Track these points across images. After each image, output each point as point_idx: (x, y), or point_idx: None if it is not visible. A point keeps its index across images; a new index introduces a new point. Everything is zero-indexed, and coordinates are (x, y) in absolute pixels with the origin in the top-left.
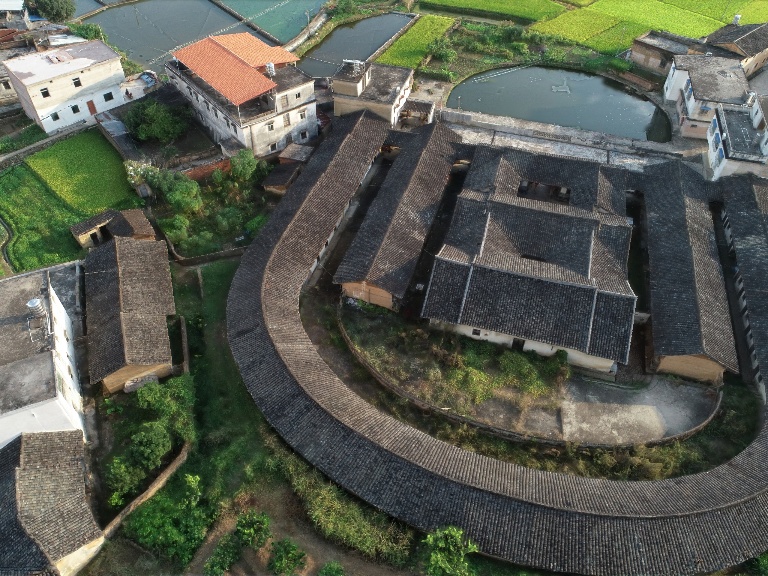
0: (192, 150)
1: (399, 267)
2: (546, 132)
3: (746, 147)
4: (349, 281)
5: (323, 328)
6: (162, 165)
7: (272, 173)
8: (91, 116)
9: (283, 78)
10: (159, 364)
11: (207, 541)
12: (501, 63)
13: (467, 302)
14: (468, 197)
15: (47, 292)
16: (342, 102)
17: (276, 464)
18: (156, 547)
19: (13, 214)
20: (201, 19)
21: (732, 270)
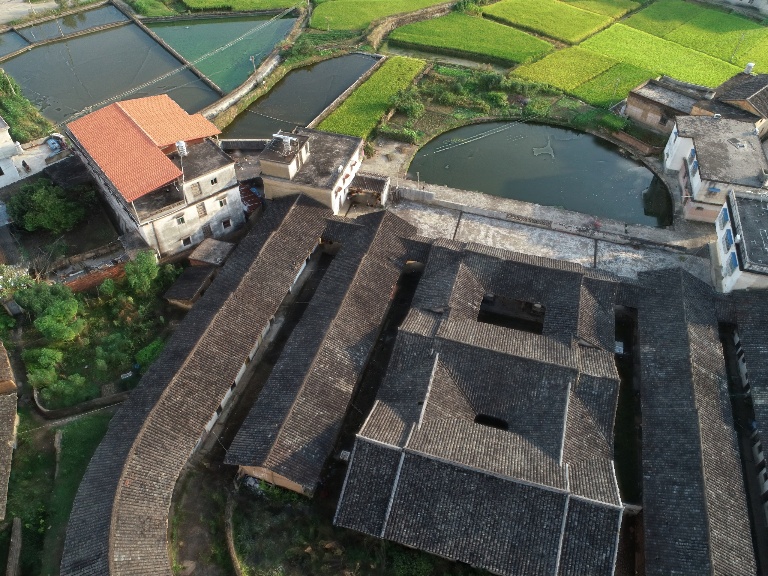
0: (90, 243)
1: (313, 439)
2: (522, 215)
3: (765, 253)
4: (243, 464)
5: (206, 530)
6: (45, 268)
7: (179, 280)
8: None
9: (196, 159)
10: None
11: None
12: (475, 118)
13: (395, 505)
14: (412, 328)
15: None
16: (273, 184)
17: None
18: None
19: None
20: (139, 60)
21: (749, 425)
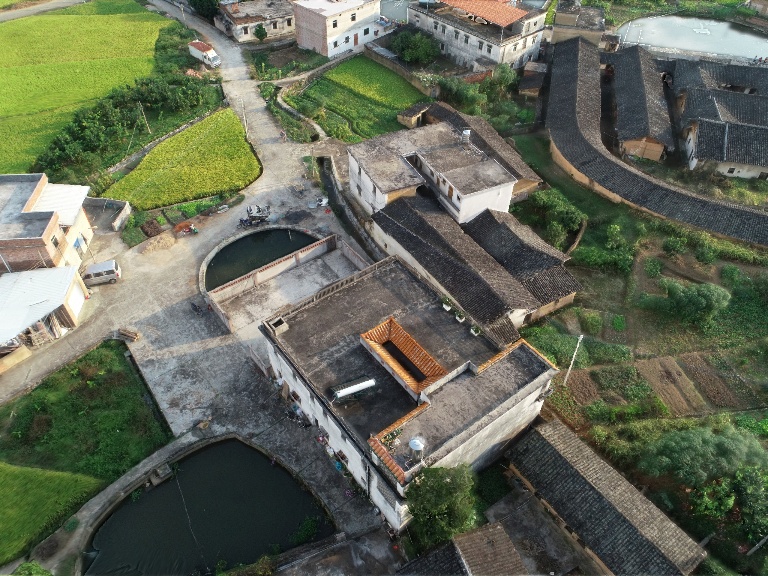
0: None
1: (664, 131)
2: (711, 57)
3: None
4: (634, 138)
5: None
6: None
7: (522, 82)
8: (354, 47)
9: None
10: (533, 183)
11: (637, 261)
12: (646, 13)
13: (728, 147)
14: None
15: (458, 132)
16: (560, 31)
17: (659, 224)
18: (602, 267)
19: (341, 109)
20: None
21: None
